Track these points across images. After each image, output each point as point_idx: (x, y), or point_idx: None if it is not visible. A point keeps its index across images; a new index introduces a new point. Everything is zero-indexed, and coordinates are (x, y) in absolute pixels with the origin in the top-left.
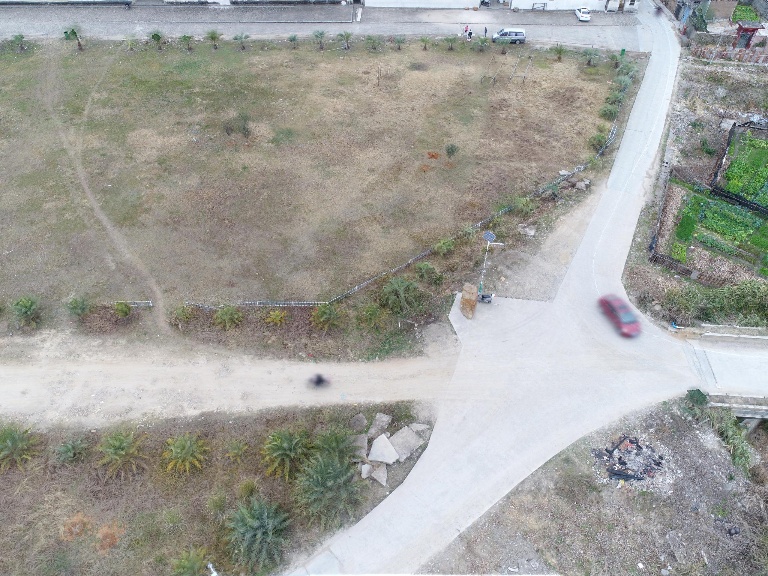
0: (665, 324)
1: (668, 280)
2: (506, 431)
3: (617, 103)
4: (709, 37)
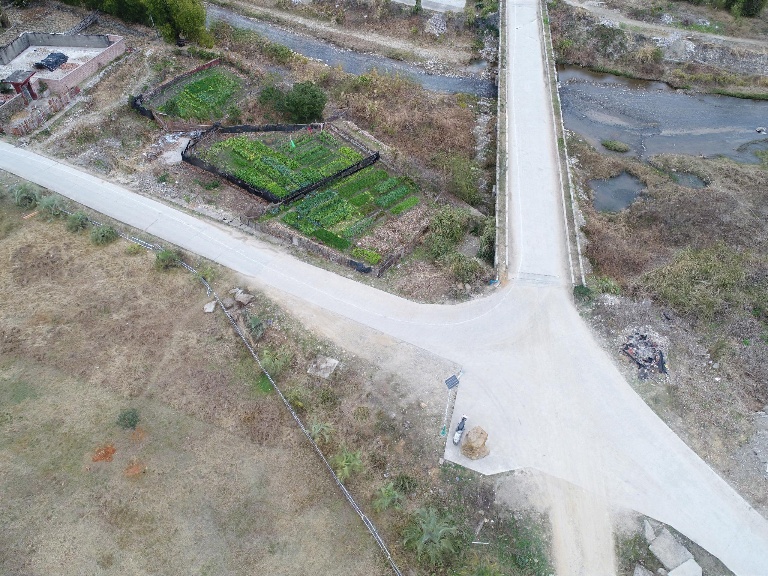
0: (490, 287)
1: (418, 271)
2: (634, 444)
3: (88, 222)
4: (6, 111)
